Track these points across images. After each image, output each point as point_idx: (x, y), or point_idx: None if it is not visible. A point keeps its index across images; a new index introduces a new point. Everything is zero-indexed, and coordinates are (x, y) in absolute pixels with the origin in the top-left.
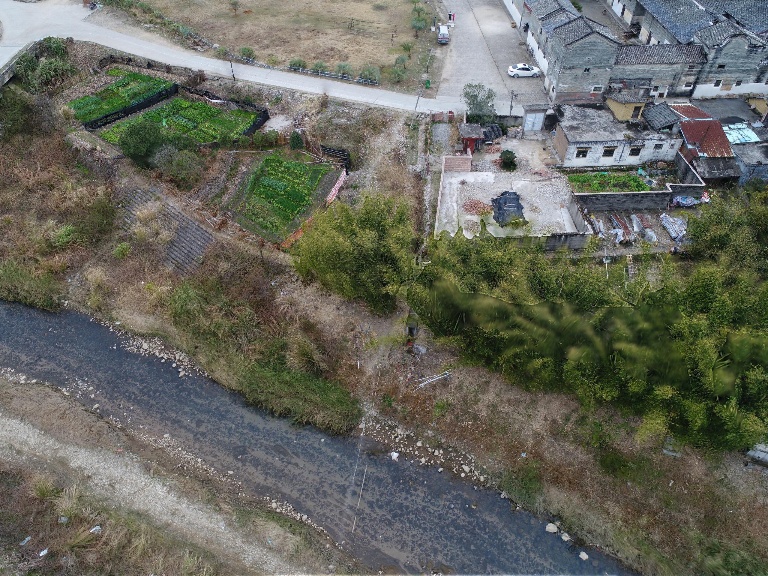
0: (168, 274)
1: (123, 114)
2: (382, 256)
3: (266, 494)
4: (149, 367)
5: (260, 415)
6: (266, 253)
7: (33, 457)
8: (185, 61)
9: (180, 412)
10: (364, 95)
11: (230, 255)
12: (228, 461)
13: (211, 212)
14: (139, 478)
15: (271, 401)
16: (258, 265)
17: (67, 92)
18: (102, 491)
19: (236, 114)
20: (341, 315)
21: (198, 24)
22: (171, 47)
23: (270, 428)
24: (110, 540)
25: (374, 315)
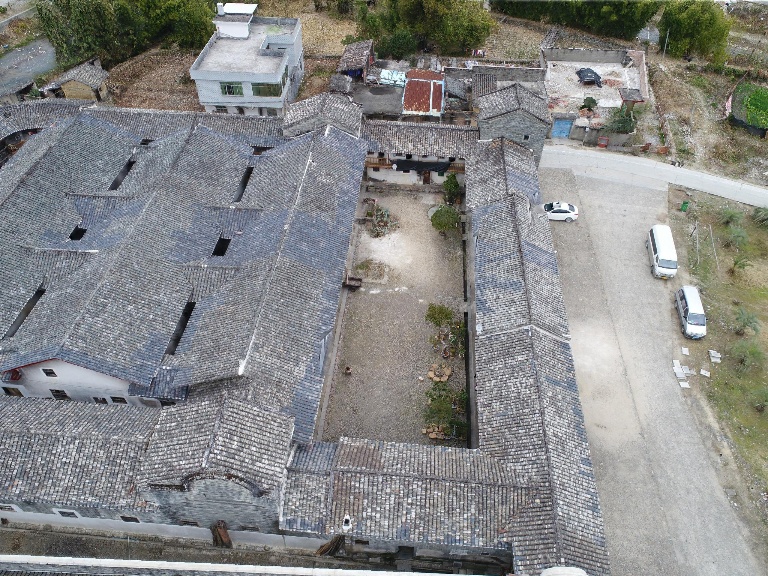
0: None
1: None
2: None
3: None
4: None
5: None
6: None
7: None
8: None
9: None
10: (760, 195)
11: None
12: None
13: None
14: None
15: None
16: None
17: None
18: None
19: None
20: None
21: None
22: None
23: None
24: None
25: None
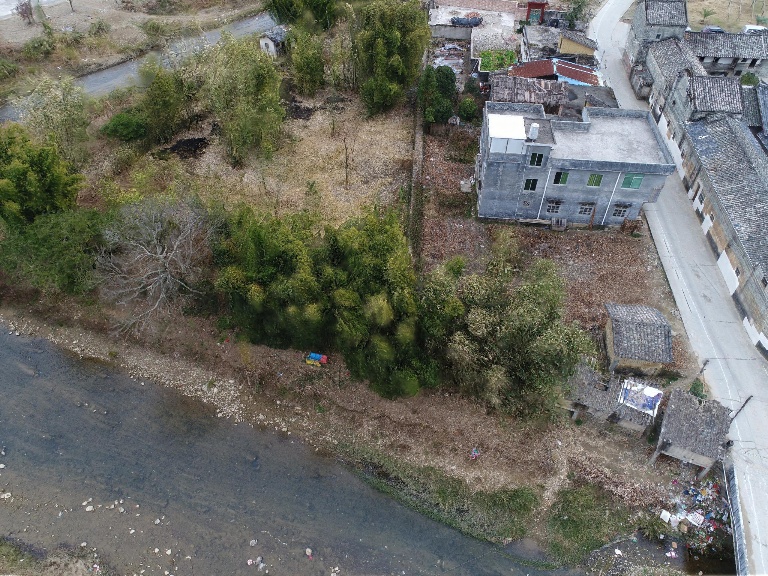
0: None
1: None
2: None
3: None
4: None
5: None
6: None
7: None
8: None
9: None
10: (618, 1)
11: None
12: None
13: None
14: None
15: None
16: None
17: None
18: None
19: None
20: None
21: None
22: None
23: None
24: None
25: None
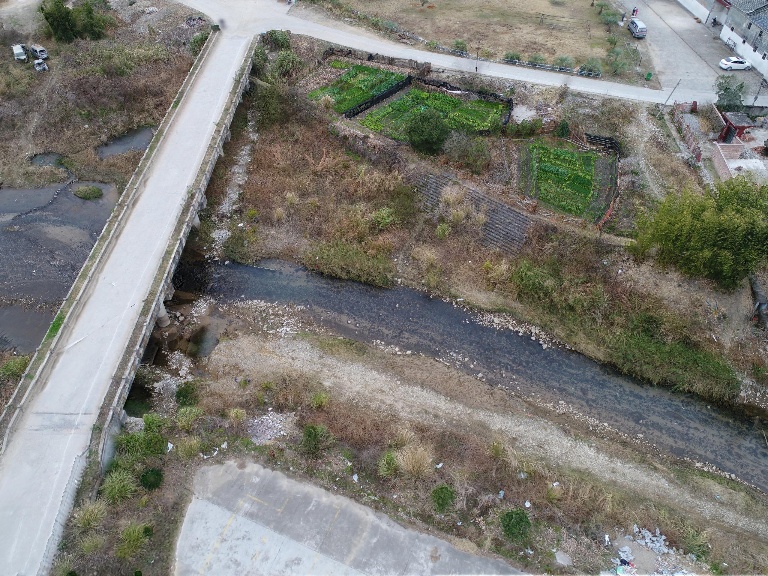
0: (497, 253)
1: (369, 104)
2: (765, 233)
3: (684, 455)
4: (509, 340)
5: (637, 384)
6: (591, 234)
7: (452, 421)
8: (401, 54)
9: (561, 381)
10: (594, 86)
11: (558, 235)
12: (631, 425)
13: (518, 195)
14: (563, 440)
15: (646, 371)
16: (584, 245)
17: (303, 83)
18: (534, 451)
19: (477, 104)
20: (684, 292)
21: (391, 18)
22: (381, 40)
23: (653, 396)
24: (578, 494)
25: (718, 291)
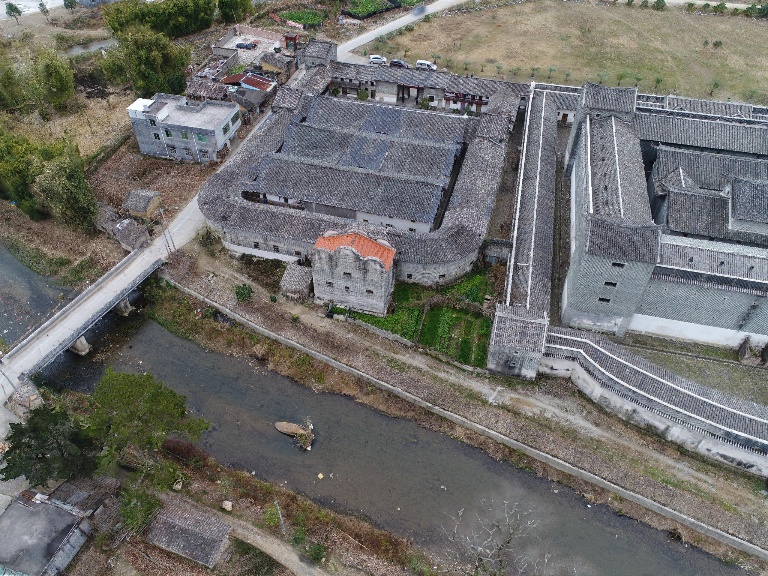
0: None
1: None
2: None
3: None
4: None
5: None
6: None
7: None
8: (431, 8)
9: None
10: None
11: None
12: None
13: (295, 4)
14: None
15: None
16: None
17: None
18: None
19: None
20: None
21: None
22: (449, 5)
23: None
24: None
25: None
